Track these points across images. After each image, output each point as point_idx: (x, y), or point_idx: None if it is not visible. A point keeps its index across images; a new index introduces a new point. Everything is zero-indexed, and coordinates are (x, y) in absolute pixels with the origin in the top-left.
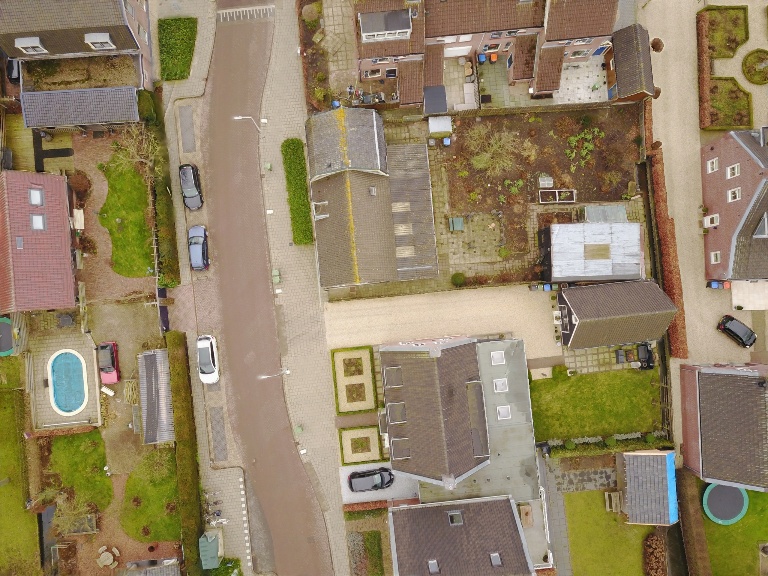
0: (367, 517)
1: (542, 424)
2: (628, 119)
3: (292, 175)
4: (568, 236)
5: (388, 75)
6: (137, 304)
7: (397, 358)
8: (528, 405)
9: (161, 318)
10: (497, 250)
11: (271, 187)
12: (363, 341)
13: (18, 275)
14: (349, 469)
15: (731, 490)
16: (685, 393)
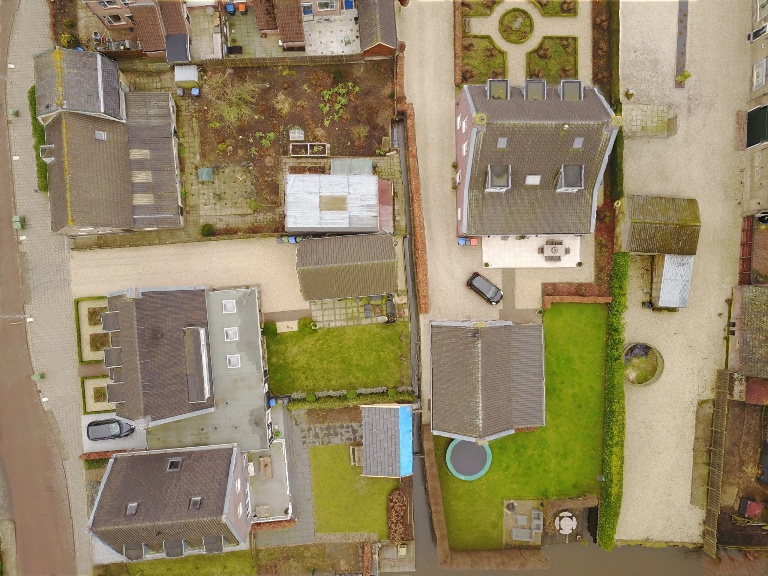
0: None
1: (288, 377)
2: (384, 75)
3: (37, 121)
4: (303, 186)
5: None
6: None
7: (118, 303)
8: (259, 354)
9: None
10: (248, 202)
11: (18, 133)
12: (110, 290)
13: None
14: (91, 418)
15: (475, 446)
16: None
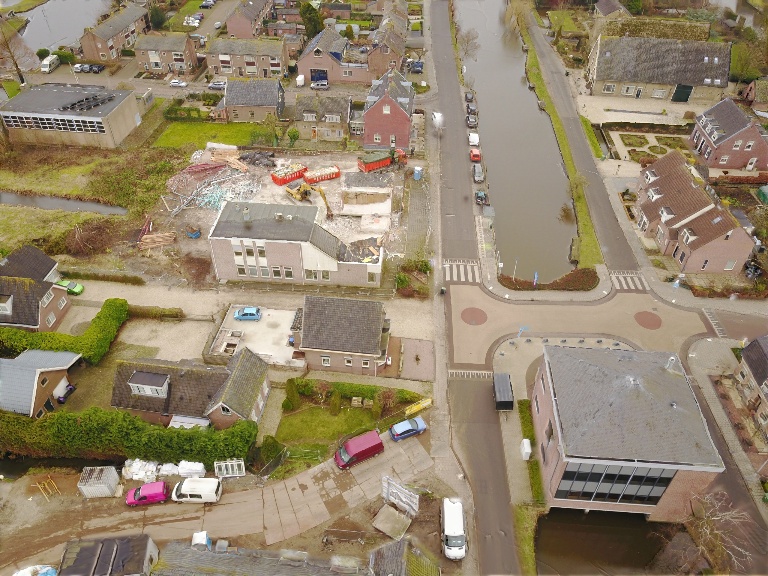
0: None
1: None
2: None
3: None
4: None
5: None
6: None
7: None
8: None
9: None
10: None
11: None
12: None
13: None
14: None
15: None
16: None
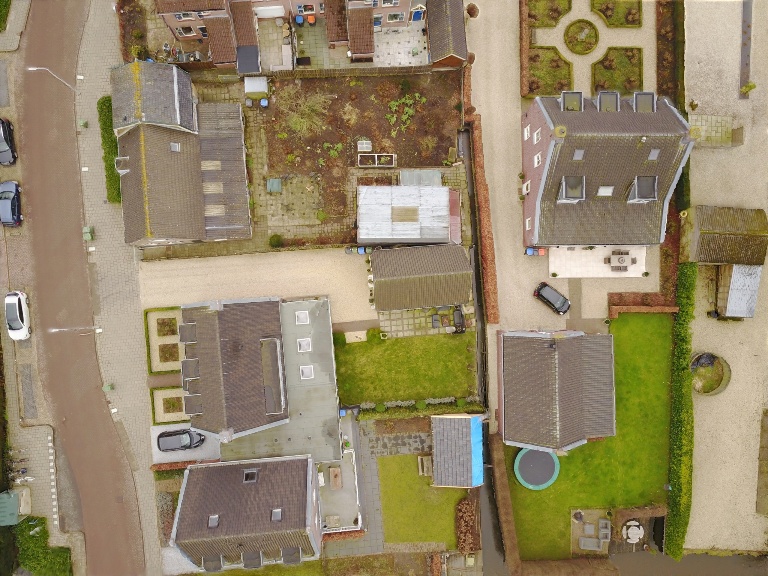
0: (177, 477)
1: (356, 387)
2: (450, 85)
3: (107, 132)
4: (376, 198)
5: (204, 34)
6: None
7: (194, 314)
8: (332, 365)
9: None
10: (316, 213)
11: (87, 144)
12: (178, 301)
13: None
14: (160, 429)
15: (542, 456)
16: (499, 358)
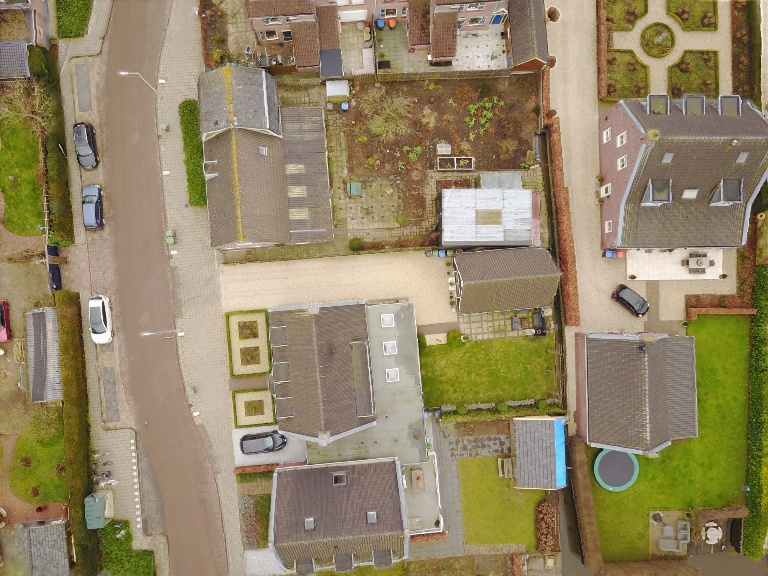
0: (259, 480)
1: (436, 390)
2: (528, 89)
3: (189, 136)
4: (460, 201)
5: (286, 38)
6: (29, 263)
7: (283, 318)
8: (417, 368)
9: (51, 276)
10: (395, 216)
11: (168, 148)
12: (259, 304)
13: None
14: (242, 432)
15: (622, 457)
16: (578, 361)
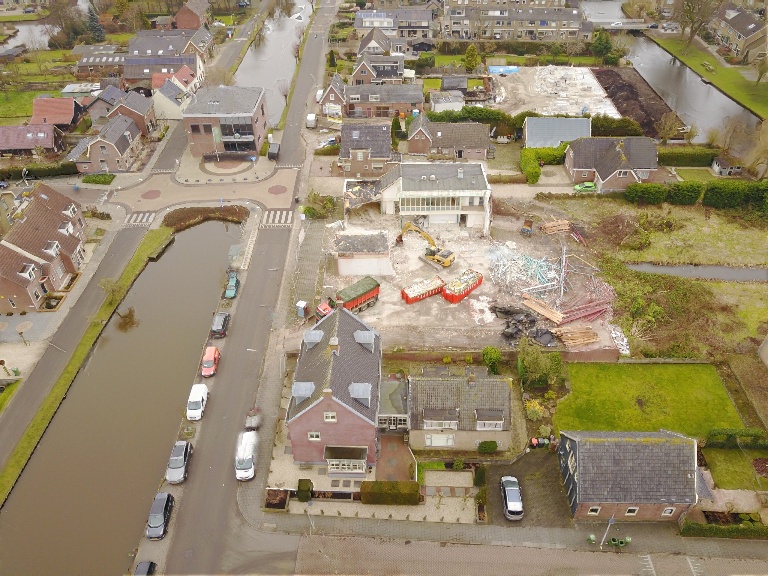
0: None
1: None
2: None
3: None
4: None
5: None
6: None
7: None
8: None
9: None
10: None
11: None
12: None
13: (8, 127)
14: None
15: None
16: None
